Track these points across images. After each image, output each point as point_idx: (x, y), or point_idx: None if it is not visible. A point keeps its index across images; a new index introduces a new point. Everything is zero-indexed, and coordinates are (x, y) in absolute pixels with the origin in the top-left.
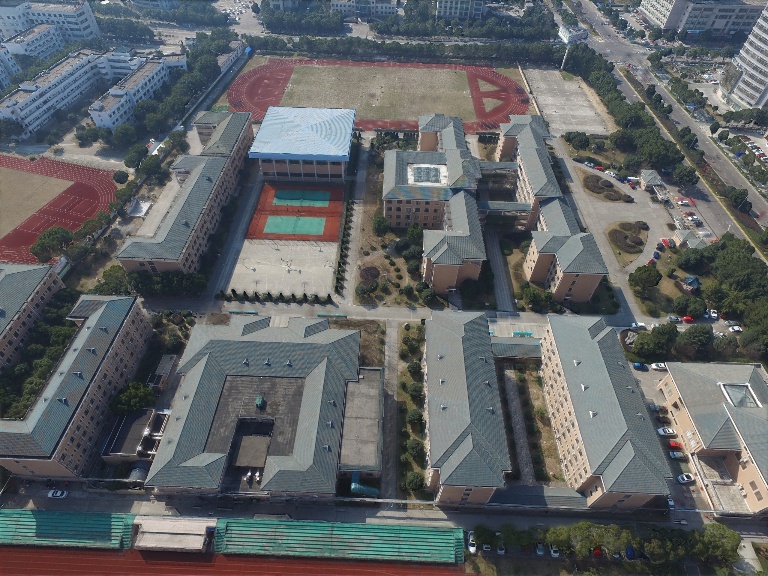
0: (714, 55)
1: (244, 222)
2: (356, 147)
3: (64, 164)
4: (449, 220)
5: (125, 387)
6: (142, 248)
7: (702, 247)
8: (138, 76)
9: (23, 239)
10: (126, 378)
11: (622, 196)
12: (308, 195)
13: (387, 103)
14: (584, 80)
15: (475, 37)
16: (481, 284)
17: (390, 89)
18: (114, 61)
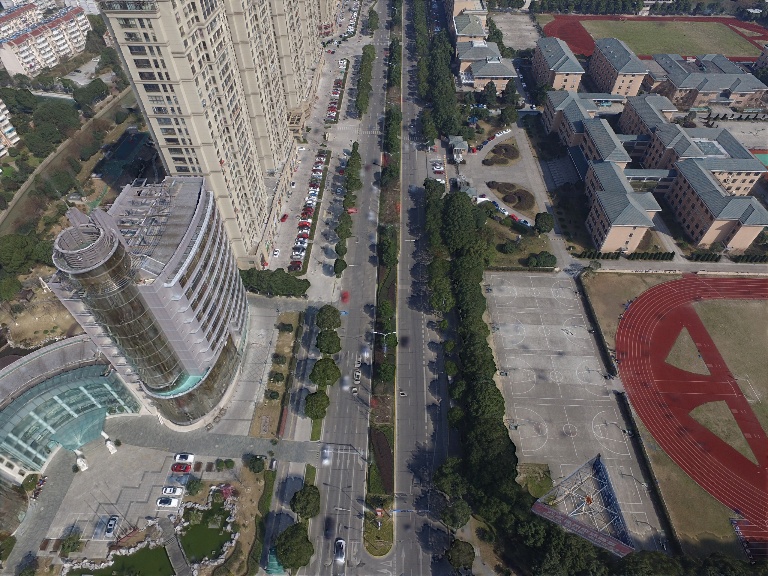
0: None
1: None
2: None
3: None
4: (663, 116)
5: None
6: None
7: None
8: None
9: None
10: None
11: (499, 184)
12: None
13: None
14: None
15: None
16: None
17: None
18: None
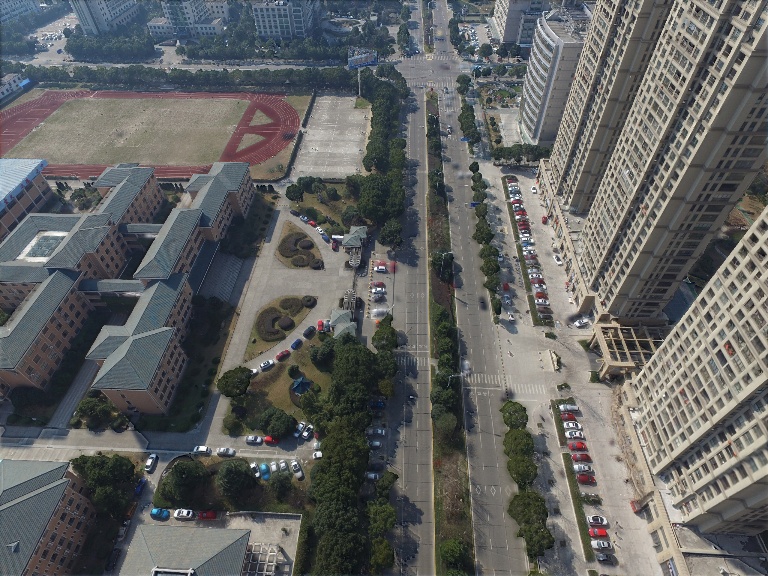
0: None
1: None
2: (51, 201)
3: None
4: (18, 311)
5: None
6: None
7: None
8: None
9: None
10: None
11: (310, 261)
12: None
13: (132, 143)
14: None
15: (290, 59)
16: (32, 393)
17: (149, 126)
18: None
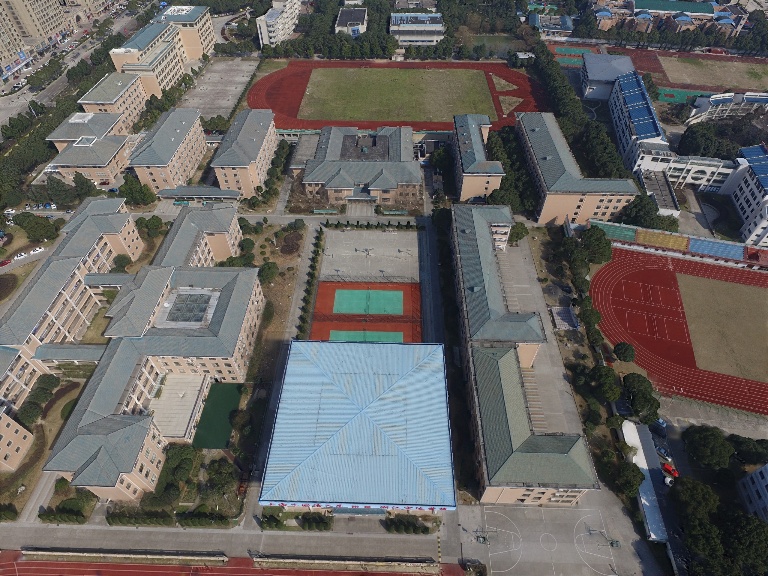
0: None
1: (429, 304)
2: None
3: (762, 410)
4: (196, 243)
5: (445, 153)
6: None
7: None
8: None
9: (653, 277)
10: None
11: None
12: None
13: None
14: None
15: None
16: None
17: None
18: None
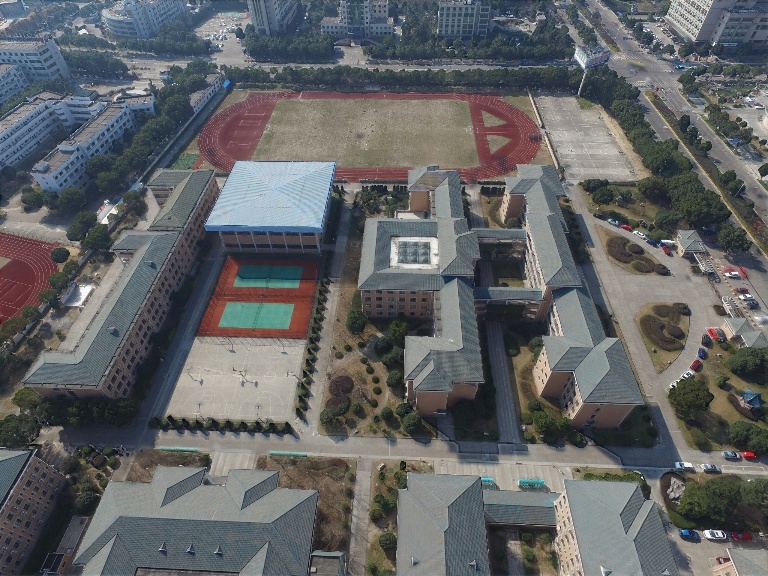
0: (757, 73)
1: (197, 312)
2: (337, 205)
3: (3, 235)
4: (438, 320)
5: None
6: (55, 371)
7: (762, 344)
8: (95, 125)
9: None
10: (18, 559)
11: (655, 267)
12: (276, 272)
13: (377, 145)
14: (605, 108)
15: (480, 58)
16: (478, 407)
17: (381, 127)
18: (74, 106)
